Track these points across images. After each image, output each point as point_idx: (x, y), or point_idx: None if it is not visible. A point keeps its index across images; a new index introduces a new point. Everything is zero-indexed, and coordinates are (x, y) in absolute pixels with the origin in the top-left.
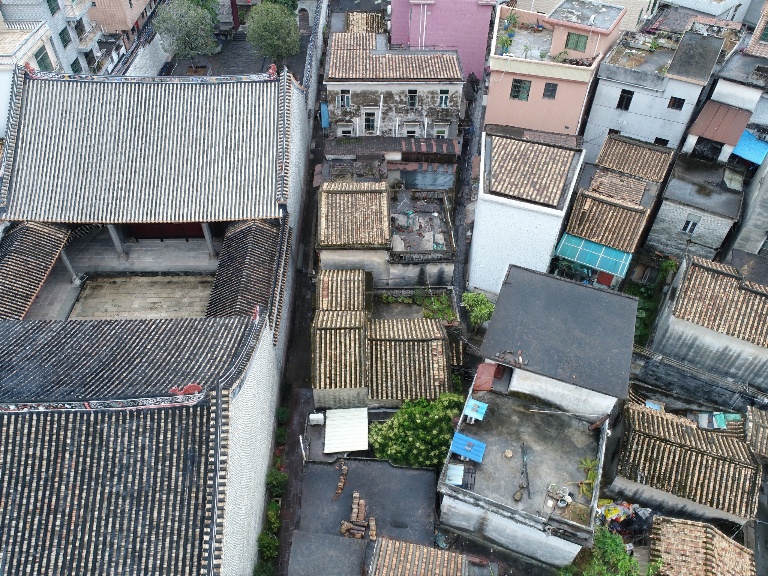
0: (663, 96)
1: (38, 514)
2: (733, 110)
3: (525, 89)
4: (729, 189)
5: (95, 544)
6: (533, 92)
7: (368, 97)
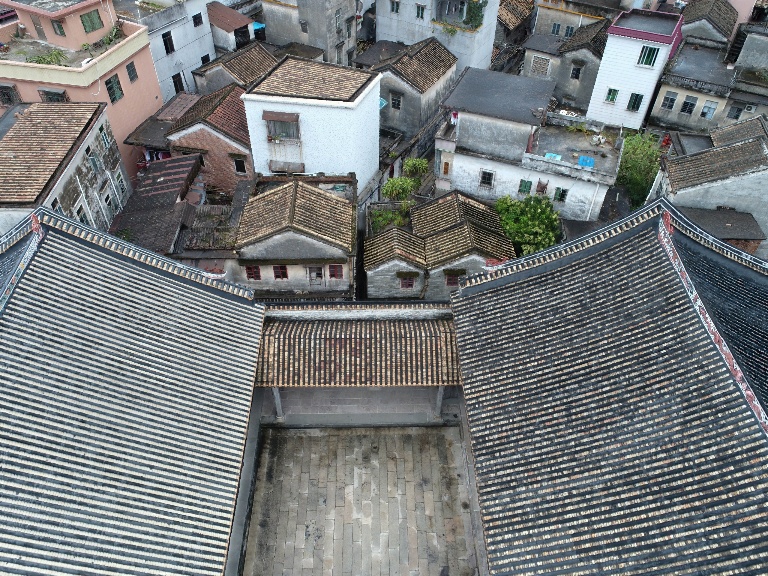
0: (188, 20)
1: (767, 365)
2: (210, 7)
3: (114, 86)
4: (288, 45)
5: (759, 331)
6: (123, 83)
7: (69, 191)
